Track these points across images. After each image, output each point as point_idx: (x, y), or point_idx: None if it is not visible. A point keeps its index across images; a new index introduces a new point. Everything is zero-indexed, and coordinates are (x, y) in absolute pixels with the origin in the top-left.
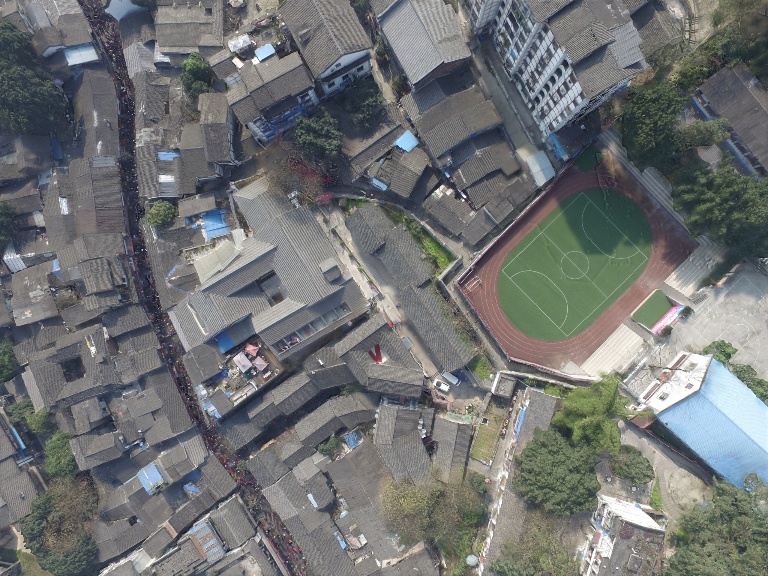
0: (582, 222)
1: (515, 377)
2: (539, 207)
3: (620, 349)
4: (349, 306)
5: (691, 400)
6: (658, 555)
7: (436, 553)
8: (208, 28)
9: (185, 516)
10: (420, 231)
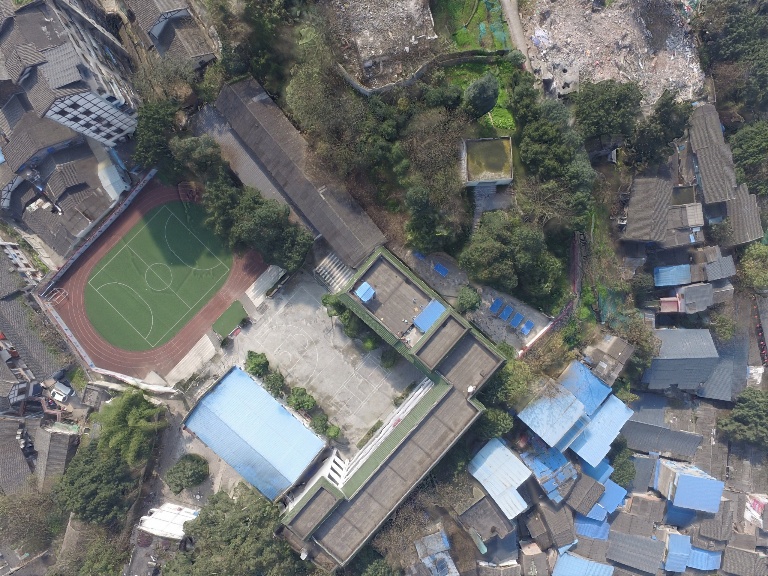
0: (165, 234)
1: (100, 387)
2: (123, 220)
3: (197, 359)
4: None
5: (199, 410)
6: None
7: None
8: None
9: None
10: (25, 244)
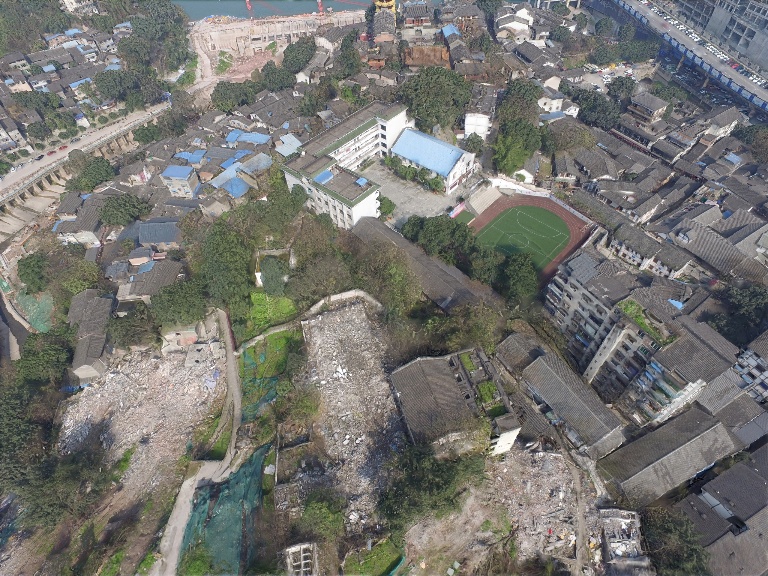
0: None
1: None
2: (555, 270)
3: (481, 200)
4: None
5: None
6: None
7: None
8: None
9: (699, 150)
10: None
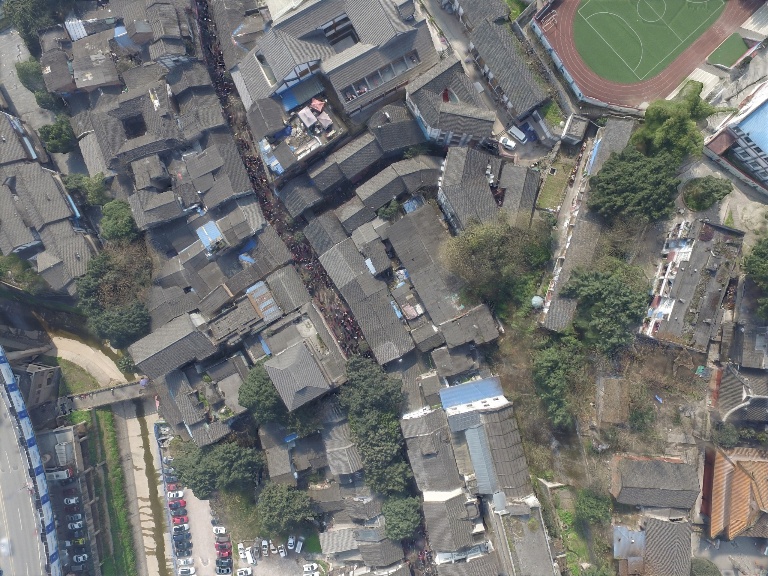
0: None
1: (587, 118)
2: None
3: None
4: (419, 55)
5: None
6: (737, 259)
7: (494, 319)
8: None
9: (241, 281)
10: None
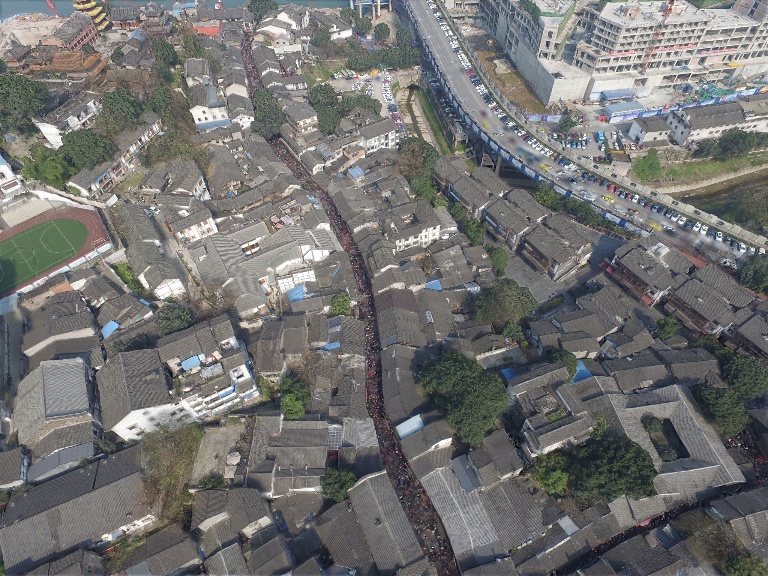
0: (1, 280)
1: None
2: None
3: (20, 212)
4: None
5: None
6: None
7: None
8: (274, 443)
9: (341, 162)
10: None
